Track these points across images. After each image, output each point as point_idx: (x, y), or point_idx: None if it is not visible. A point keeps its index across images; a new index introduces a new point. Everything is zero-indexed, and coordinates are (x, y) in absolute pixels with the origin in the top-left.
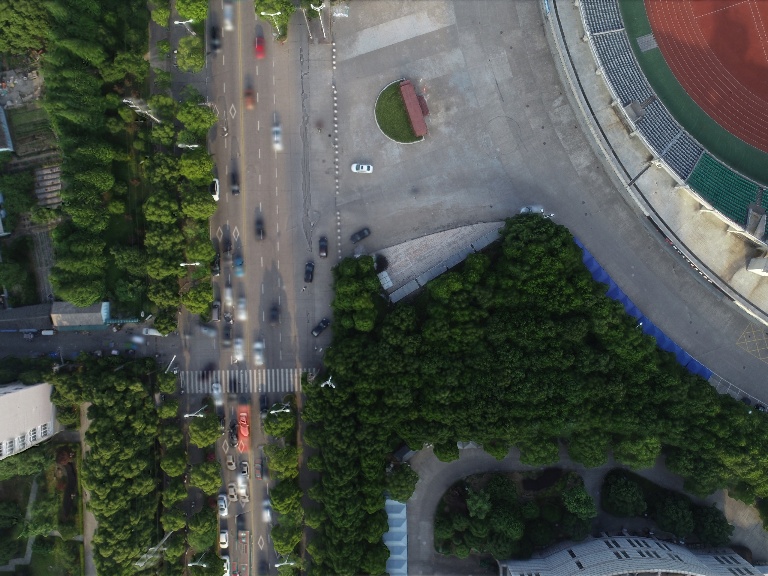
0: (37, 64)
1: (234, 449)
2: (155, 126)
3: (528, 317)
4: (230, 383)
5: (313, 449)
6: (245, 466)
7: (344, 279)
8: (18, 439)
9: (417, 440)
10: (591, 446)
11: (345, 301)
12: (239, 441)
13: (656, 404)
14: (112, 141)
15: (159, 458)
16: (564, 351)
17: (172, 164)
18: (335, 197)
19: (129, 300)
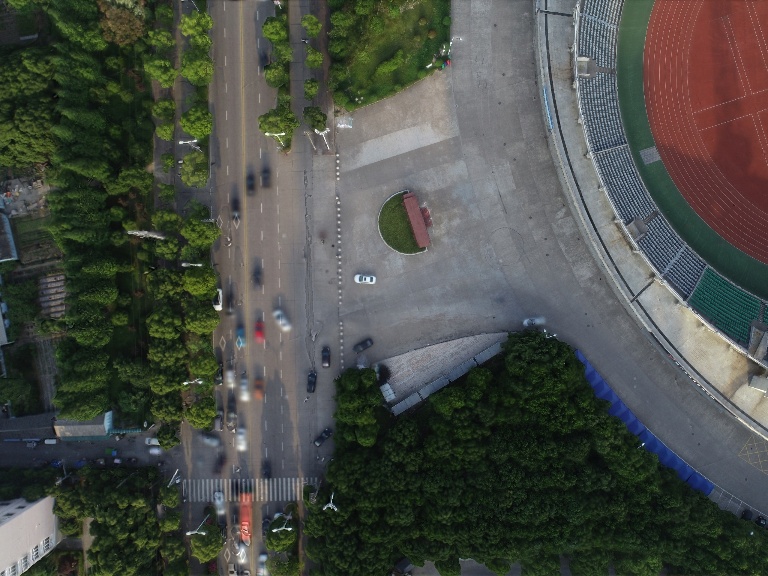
0: (42, 174)
1: (236, 558)
2: (159, 243)
3: (530, 437)
4: (232, 492)
5: (315, 563)
6: (247, 575)
7: (347, 394)
8: (21, 561)
9: (419, 559)
10: (593, 566)
11: (347, 418)
12: (241, 550)
13: (658, 523)
14: (116, 252)
15: (161, 568)
16: (566, 470)
17: (176, 280)
18: (338, 307)
19: (132, 411)
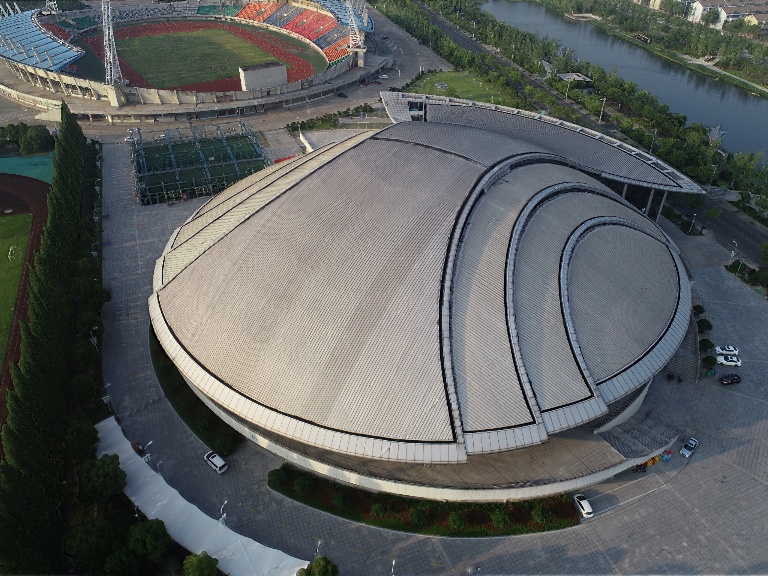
0: None
1: None
2: None
3: None
4: None
5: None
6: None
7: None
8: None
9: None
10: None
11: None
12: None
13: None
14: None
15: None
16: None
17: None
18: None
19: None
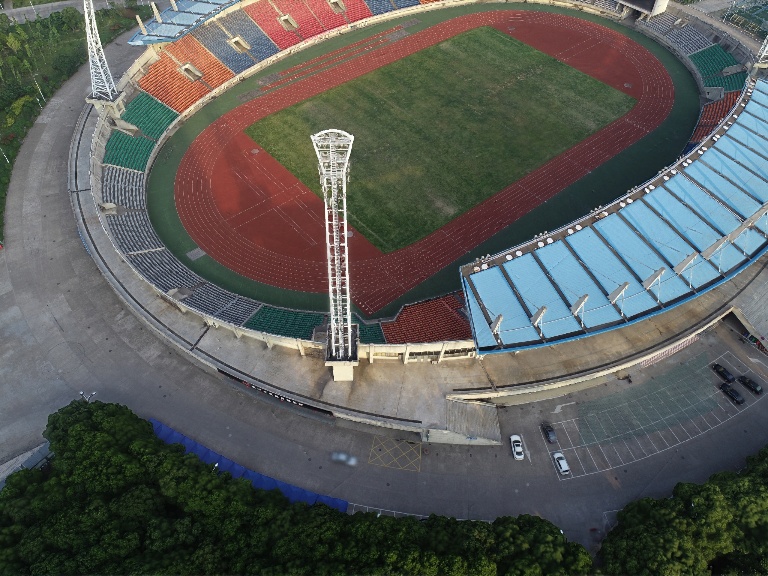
0: None
1: None
2: None
3: None
4: None
5: None
6: None
7: None
8: None
9: None
10: None
11: None
12: None
13: (265, 556)
14: None
15: None
16: None
17: None
18: None
19: None
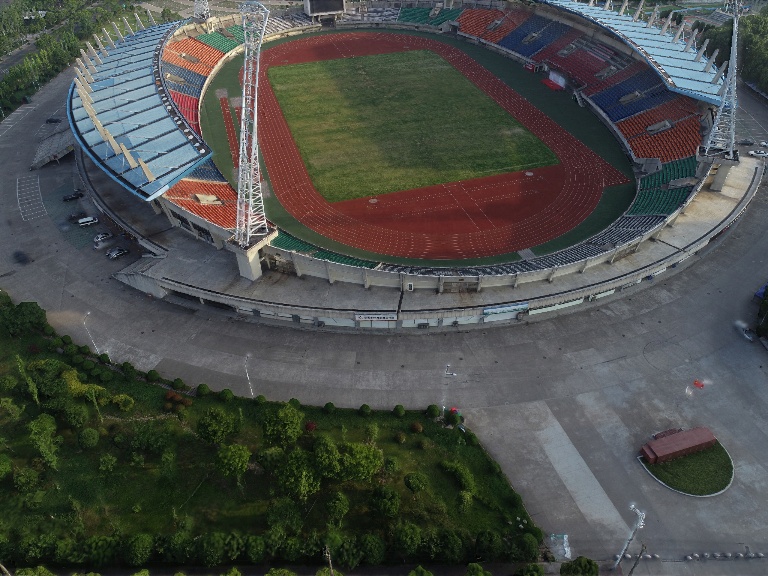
0: None
1: None
2: None
3: None
4: None
5: None
6: None
7: None
8: None
9: None
10: None
11: None
12: None
13: None
14: None
15: None
16: None
17: None
18: None
19: None
